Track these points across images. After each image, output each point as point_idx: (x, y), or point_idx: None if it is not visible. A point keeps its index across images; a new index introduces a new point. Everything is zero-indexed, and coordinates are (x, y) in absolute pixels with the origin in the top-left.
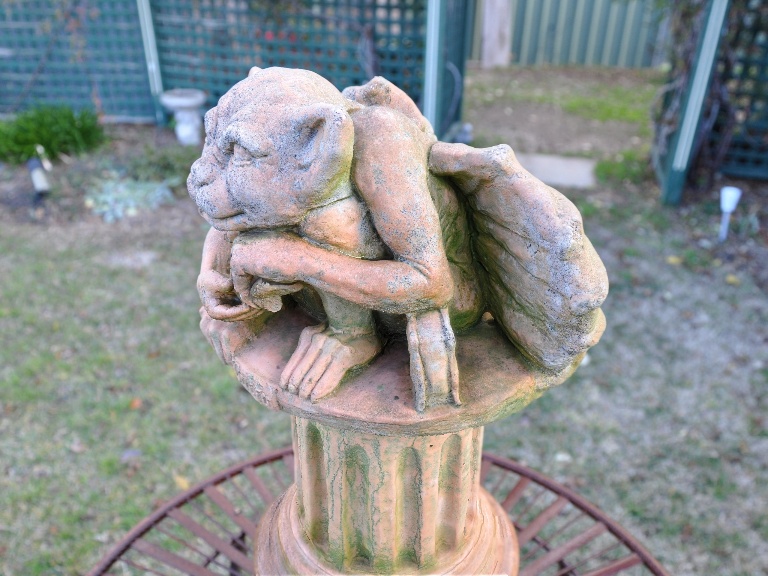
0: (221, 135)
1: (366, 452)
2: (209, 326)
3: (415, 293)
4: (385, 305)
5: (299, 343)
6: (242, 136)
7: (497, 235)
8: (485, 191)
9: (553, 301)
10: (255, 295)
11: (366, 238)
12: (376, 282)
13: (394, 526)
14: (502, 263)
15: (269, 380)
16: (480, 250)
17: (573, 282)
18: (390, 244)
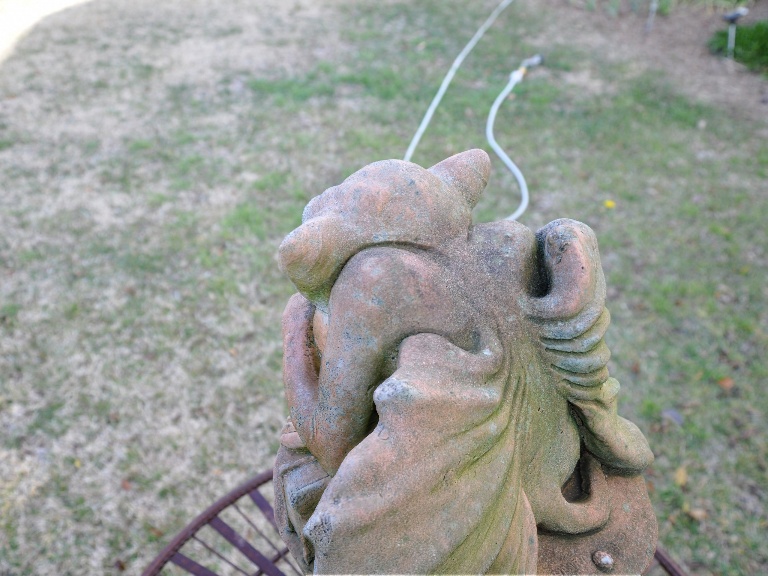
0: None
1: None
2: None
3: None
4: None
5: None
6: (305, 209)
7: None
8: None
9: None
10: None
11: None
12: None
13: None
14: None
15: None
16: None
17: None
18: None
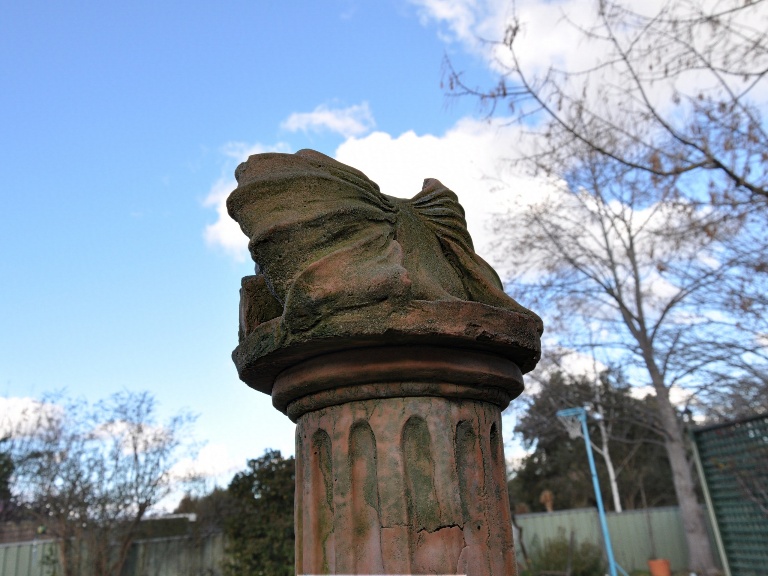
0: None
1: None
2: None
3: None
4: None
5: None
6: None
7: None
8: None
9: None
10: None
11: None
12: None
13: (298, 545)
14: None
15: None
16: None
17: None
18: None
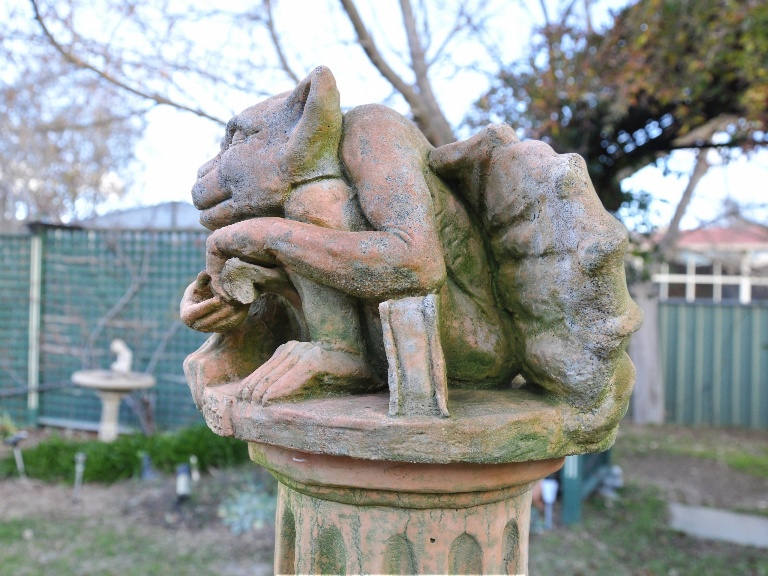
0: None
1: (343, 538)
2: None
3: (392, 258)
4: (357, 274)
5: None
6: (239, 117)
7: (509, 240)
8: (489, 183)
9: (562, 268)
10: (224, 276)
11: (352, 221)
12: (347, 241)
13: None
14: (518, 277)
15: (227, 394)
16: (502, 287)
17: (577, 224)
18: (372, 215)
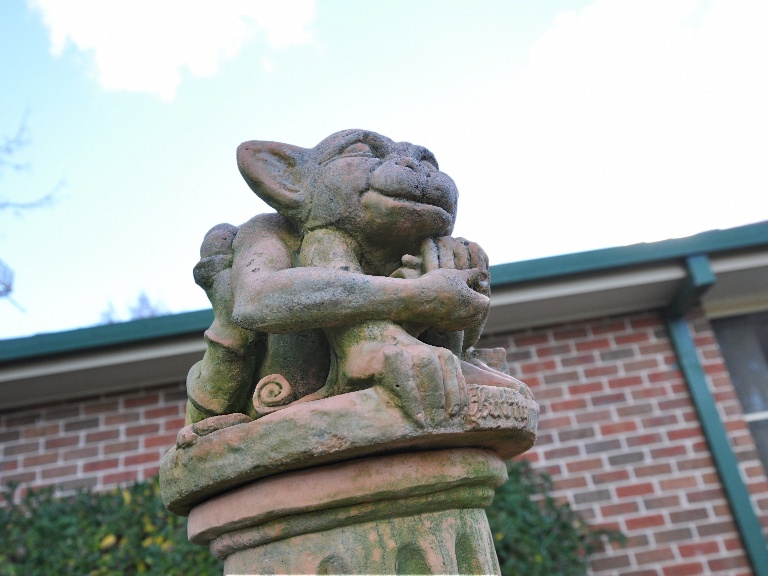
0: (415, 148)
1: None
2: (437, 353)
3: None
4: None
5: (474, 368)
6: None
7: None
8: None
9: None
10: None
11: None
12: None
13: None
14: None
15: None
16: None
17: None
18: None
